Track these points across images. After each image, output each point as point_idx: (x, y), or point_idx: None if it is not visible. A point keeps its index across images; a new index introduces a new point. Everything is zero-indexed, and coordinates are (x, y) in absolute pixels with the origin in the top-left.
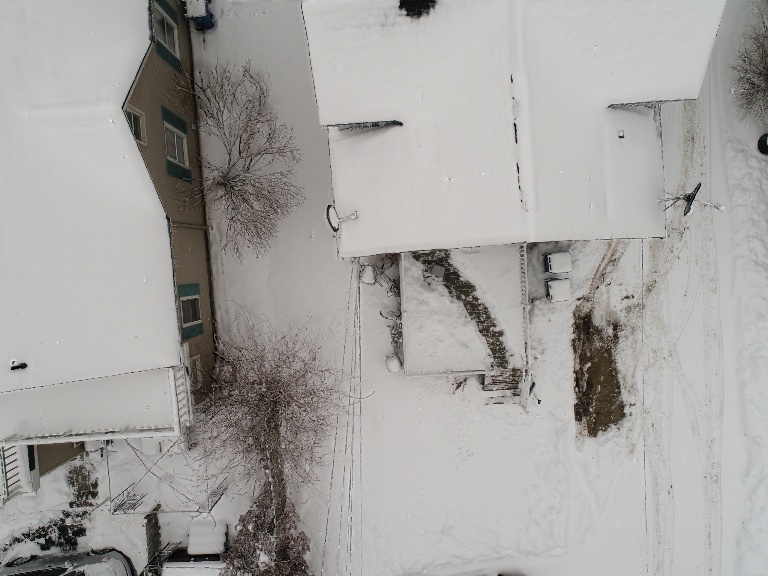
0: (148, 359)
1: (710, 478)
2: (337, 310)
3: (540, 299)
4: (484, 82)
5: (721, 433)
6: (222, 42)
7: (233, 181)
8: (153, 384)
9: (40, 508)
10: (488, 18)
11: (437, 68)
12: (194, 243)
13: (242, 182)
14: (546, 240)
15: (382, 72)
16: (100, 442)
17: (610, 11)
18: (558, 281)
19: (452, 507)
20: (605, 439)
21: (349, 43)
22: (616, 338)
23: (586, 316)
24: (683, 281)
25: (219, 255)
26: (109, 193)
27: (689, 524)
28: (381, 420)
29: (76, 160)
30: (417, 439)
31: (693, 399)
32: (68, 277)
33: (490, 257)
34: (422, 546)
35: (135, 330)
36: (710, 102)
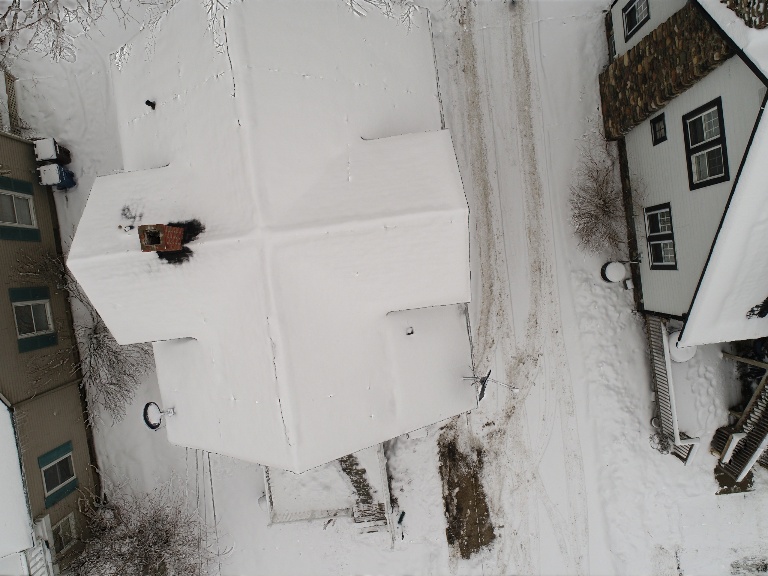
0: None
1: None
2: None
3: None
4: (249, 318)
5: (588, 550)
6: (84, 199)
7: None
8: (13, 561)
9: None
10: (245, 262)
11: (211, 299)
12: (63, 402)
13: (100, 346)
14: (315, 466)
15: (161, 305)
16: None
17: (360, 248)
18: None
19: None
20: (477, 561)
21: (121, 287)
22: (481, 463)
23: (451, 444)
24: (541, 406)
25: None
26: None
27: None
28: (263, 552)
29: None
30: (298, 569)
31: (559, 519)
32: None
33: None
34: None
35: None
36: (553, 233)
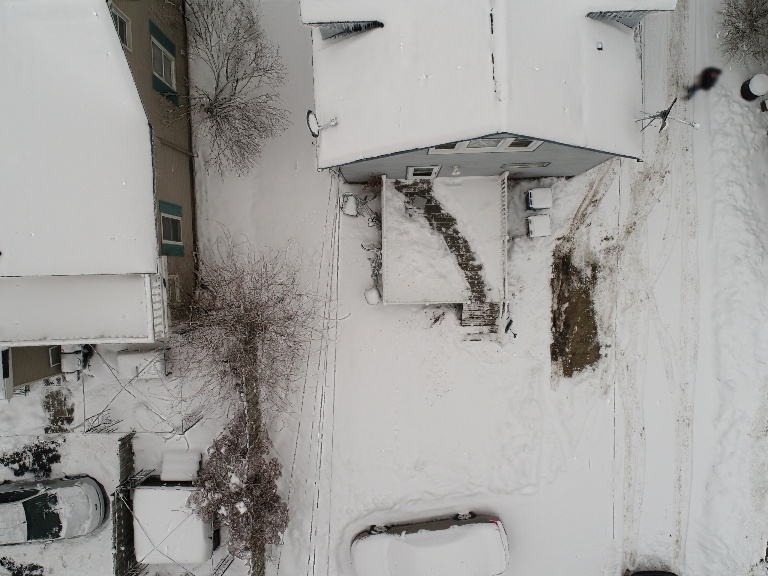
0: (124, 262)
1: (682, 421)
2: (319, 242)
3: (520, 237)
4: None
5: (695, 377)
6: None
7: (219, 104)
8: (129, 294)
9: (15, 431)
10: None
11: None
12: (178, 166)
13: None
14: (518, 133)
15: None
16: (77, 364)
17: None
18: (538, 216)
19: (426, 443)
20: (580, 379)
21: None
22: (594, 279)
23: (565, 256)
24: (662, 224)
25: (203, 183)
26: (91, 92)
27: (660, 467)
28: (358, 354)
29: (59, 56)
30: (394, 374)
31: (668, 342)
32: (46, 171)
33: (472, 190)
34: (395, 481)
35: (112, 232)
36: (695, 47)
